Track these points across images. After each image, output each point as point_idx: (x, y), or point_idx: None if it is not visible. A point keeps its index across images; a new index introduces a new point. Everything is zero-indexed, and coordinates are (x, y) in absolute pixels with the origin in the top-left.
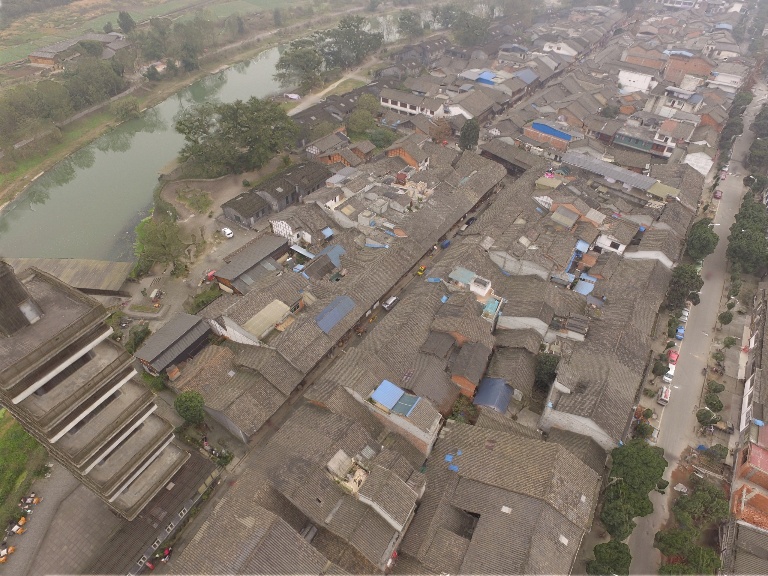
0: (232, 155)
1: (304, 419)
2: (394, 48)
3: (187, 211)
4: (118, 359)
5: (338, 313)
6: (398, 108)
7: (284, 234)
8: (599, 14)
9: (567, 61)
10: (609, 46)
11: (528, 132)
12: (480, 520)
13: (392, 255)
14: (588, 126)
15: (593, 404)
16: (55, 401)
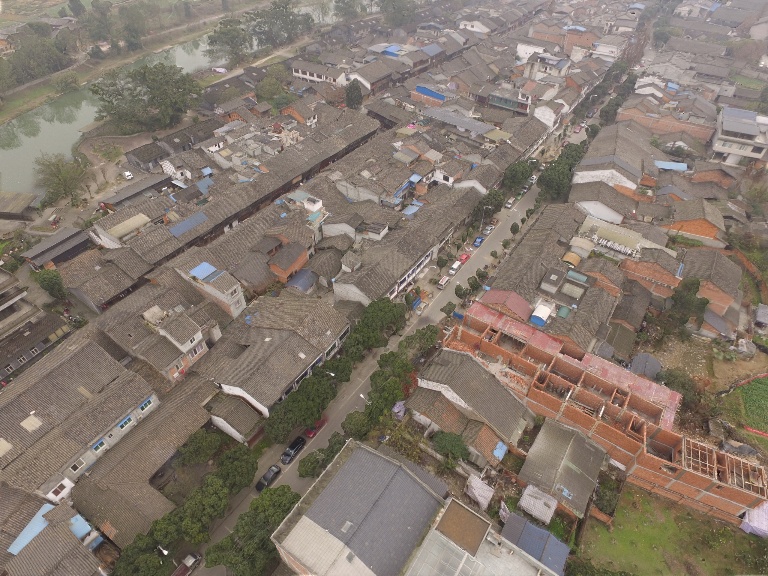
0: (142, 114)
1: (141, 292)
2: (328, 29)
3: (99, 160)
4: None
5: (190, 223)
6: (308, 77)
7: (171, 173)
8: None
9: (480, 38)
10: (525, 25)
11: (414, 95)
12: (249, 347)
13: (250, 184)
14: None
15: (360, 276)
16: None
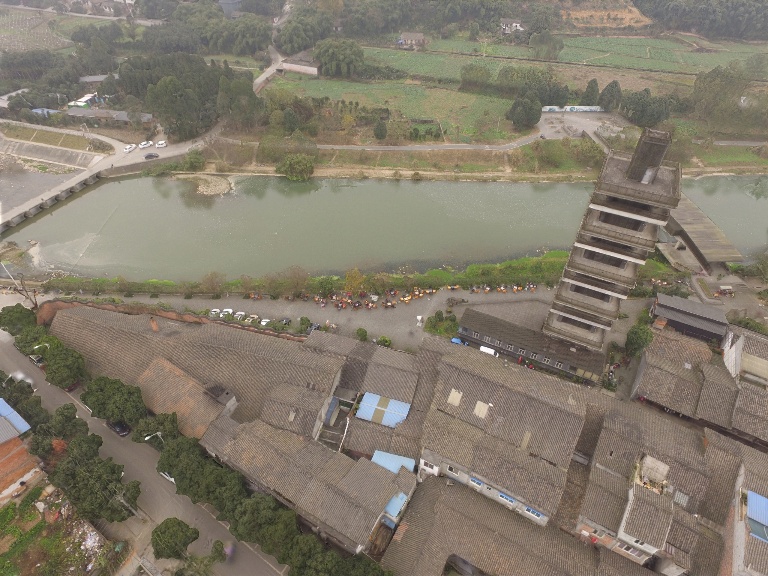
0: None
1: (681, 433)
2: None
3: None
4: (647, 240)
5: None
6: None
7: None
8: None
9: None
10: None
11: None
12: None
13: None
14: None
15: None
16: None
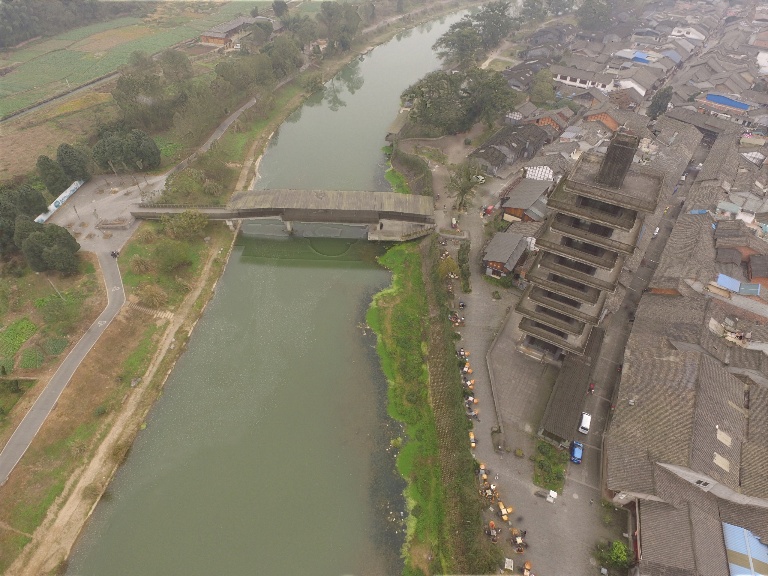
0: None
1: (657, 302)
2: (520, 33)
3: (430, 163)
4: None
5: None
6: (567, 83)
7: (540, 178)
8: (706, 3)
9: None
10: (728, 32)
11: None
12: None
13: None
14: (754, 99)
15: None
16: (621, 241)
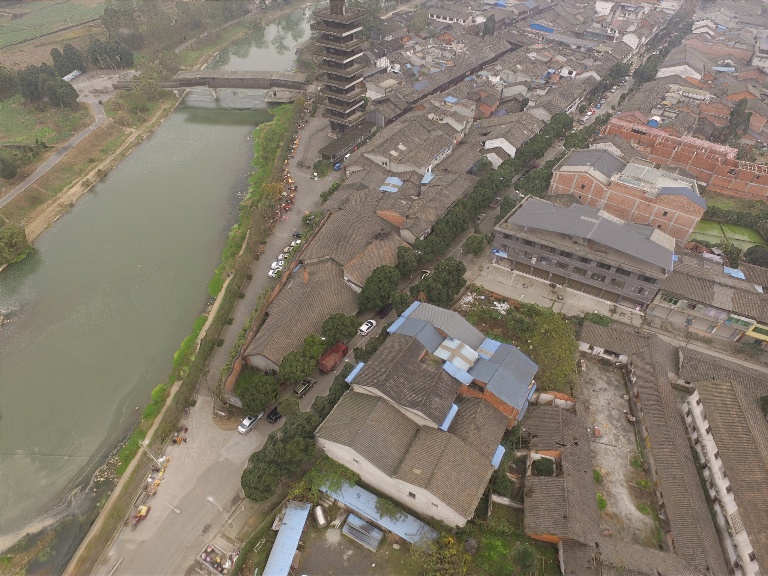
0: None
1: None
2: None
3: None
4: None
5: (422, 85)
6: (441, 21)
7: None
8: None
9: None
10: None
11: None
12: None
13: (447, 69)
14: (567, 28)
15: None
16: None
